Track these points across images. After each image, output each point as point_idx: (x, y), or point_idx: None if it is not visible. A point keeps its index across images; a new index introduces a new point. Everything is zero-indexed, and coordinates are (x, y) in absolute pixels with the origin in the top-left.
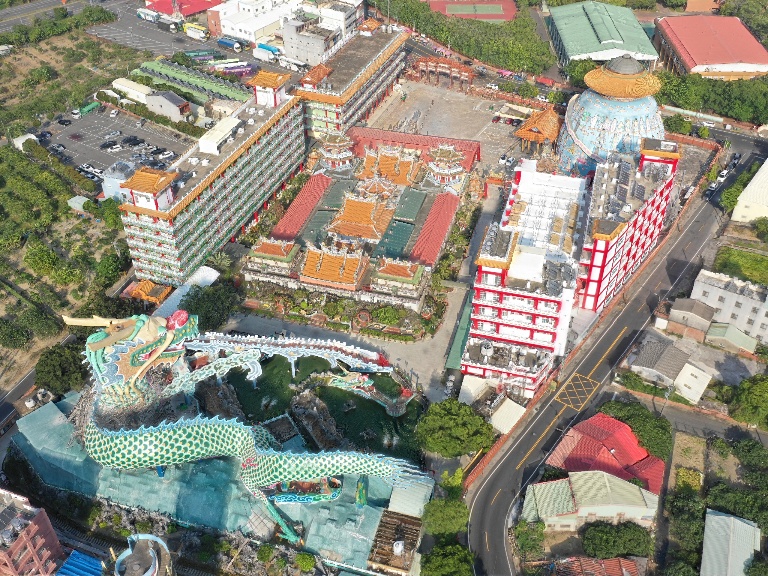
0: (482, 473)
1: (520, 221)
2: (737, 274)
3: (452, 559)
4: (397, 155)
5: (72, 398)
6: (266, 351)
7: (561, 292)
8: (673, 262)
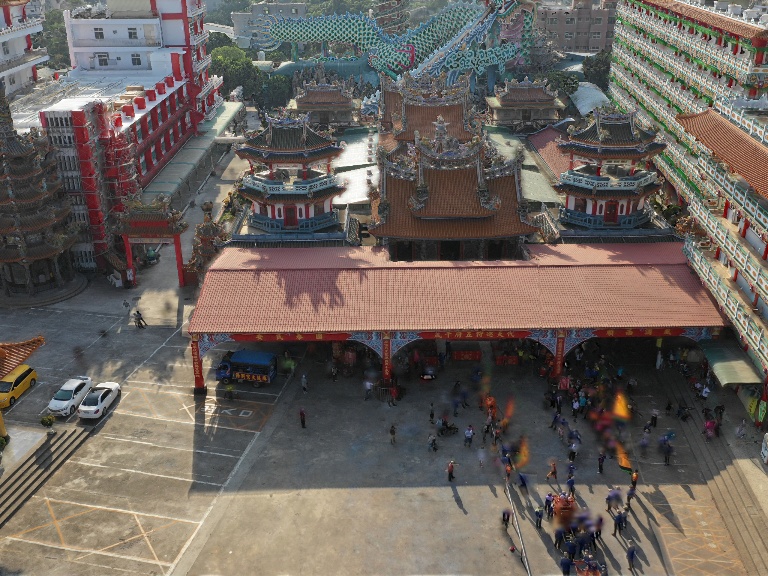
0: None
1: None
2: None
3: None
4: (429, 163)
5: (580, 65)
6: (432, 63)
7: (101, 7)
8: None
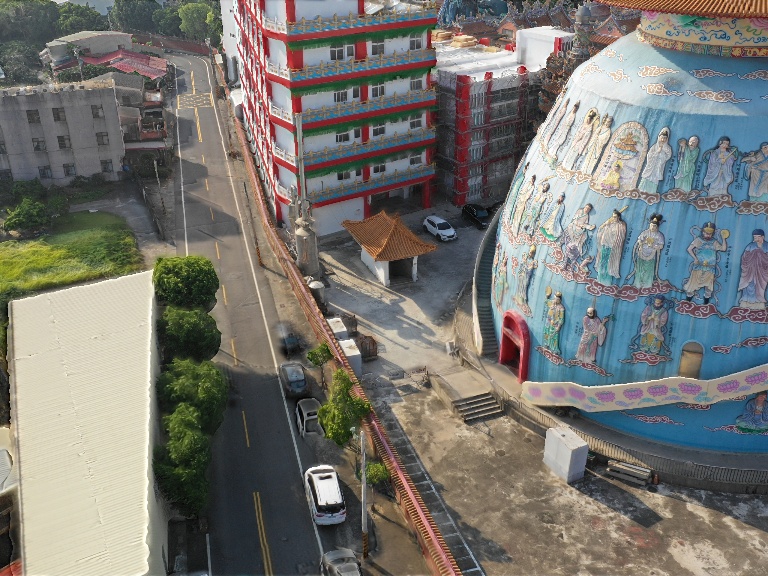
0: (215, 63)
1: (432, 41)
2: (74, 236)
3: (169, 8)
4: None
5: None
6: None
7: None
8: (218, 217)
